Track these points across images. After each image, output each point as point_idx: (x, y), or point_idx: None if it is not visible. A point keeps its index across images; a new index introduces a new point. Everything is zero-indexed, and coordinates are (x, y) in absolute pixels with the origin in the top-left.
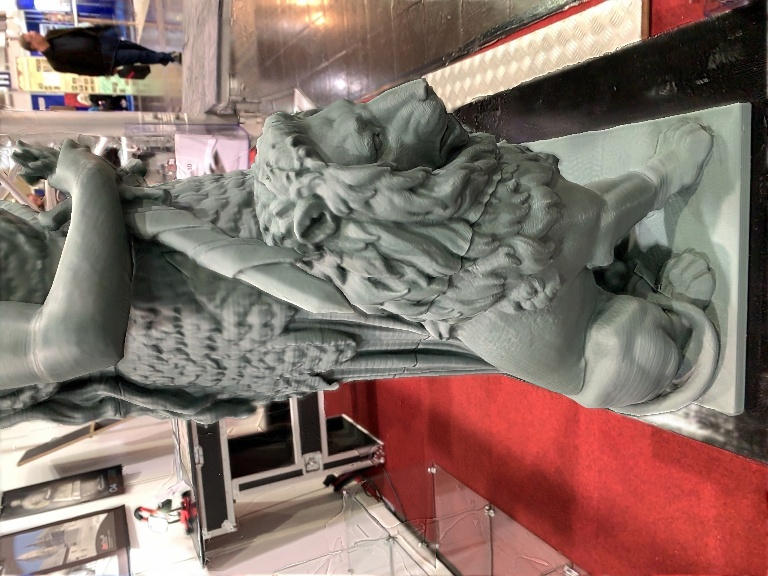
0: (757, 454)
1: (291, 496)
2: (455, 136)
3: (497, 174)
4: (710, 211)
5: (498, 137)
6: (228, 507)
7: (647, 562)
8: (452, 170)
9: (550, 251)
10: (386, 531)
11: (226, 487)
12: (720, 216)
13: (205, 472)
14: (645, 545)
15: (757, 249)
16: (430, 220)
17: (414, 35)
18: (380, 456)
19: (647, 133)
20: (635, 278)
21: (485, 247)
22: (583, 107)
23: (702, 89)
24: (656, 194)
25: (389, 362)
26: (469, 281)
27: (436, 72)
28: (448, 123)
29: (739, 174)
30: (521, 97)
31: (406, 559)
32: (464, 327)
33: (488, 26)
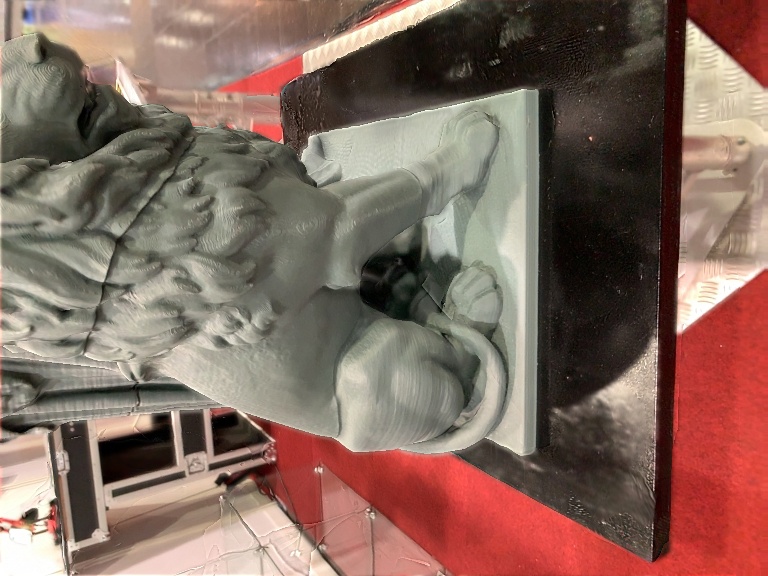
0: (548, 500)
1: (179, 497)
2: (108, 116)
3: (168, 170)
4: (497, 218)
5: (319, 121)
6: (99, 515)
7: (511, 570)
8: (77, 164)
9: (245, 273)
10: (257, 541)
11: (97, 494)
12: (506, 224)
13: (72, 479)
14: (509, 552)
15: (546, 264)
16: (45, 233)
17: (297, 8)
18: (271, 454)
19: (441, 122)
20: (420, 294)
21: (136, 270)
22: (390, 89)
23: (495, 72)
24: (427, 197)
25: (97, 403)
26: (128, 314)
27: (316, 49)
28: (97, 98)
29: (524, 175)
30: (336, 75)
31: (274, 571)
32: (164, 365)
33: (365, 1)
